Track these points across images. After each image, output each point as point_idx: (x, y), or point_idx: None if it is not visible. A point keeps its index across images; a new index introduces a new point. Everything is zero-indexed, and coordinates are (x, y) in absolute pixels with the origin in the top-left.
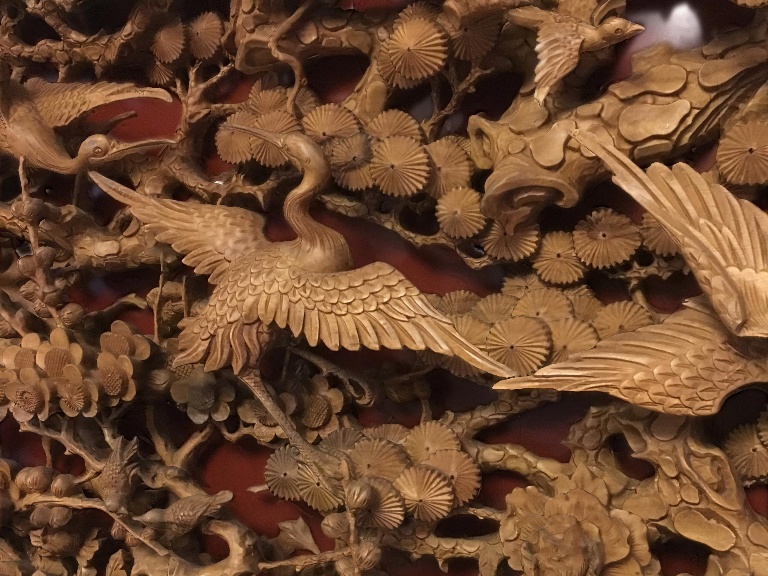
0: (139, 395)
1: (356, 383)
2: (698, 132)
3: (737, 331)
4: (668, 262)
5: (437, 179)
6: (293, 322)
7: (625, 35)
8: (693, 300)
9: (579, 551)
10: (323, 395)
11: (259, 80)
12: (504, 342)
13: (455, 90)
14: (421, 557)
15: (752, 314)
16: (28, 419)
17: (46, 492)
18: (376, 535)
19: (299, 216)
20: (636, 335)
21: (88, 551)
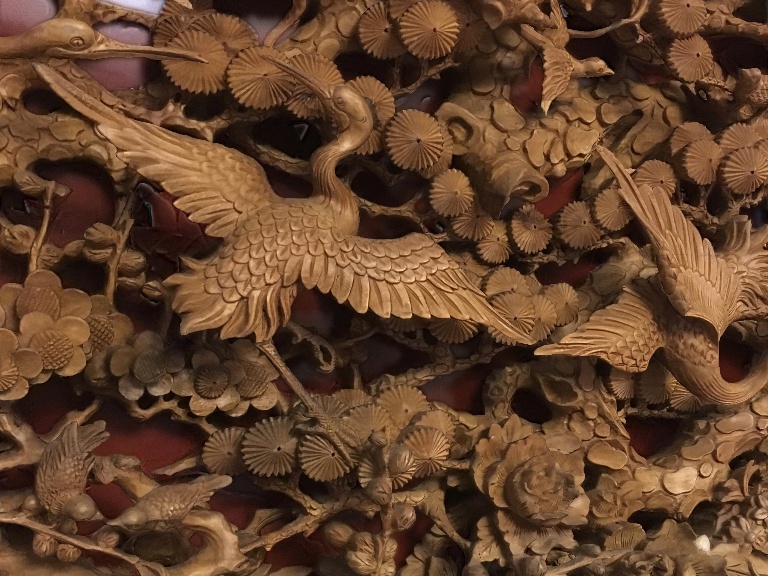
0: None
1: (325, 349)
2: None
3: None
4: (565, 253)
5: None
6: (339, 287)
7: (601, 74)
8: (628, 287)
9: None
10: (255, 362)
11: None
12: (508, 314)
13: (424, 73)
14: (375, 514)
15: None
16: None
17: None
18: (338, 500)
19: (334, 175)
20: (607, 312)
21: None
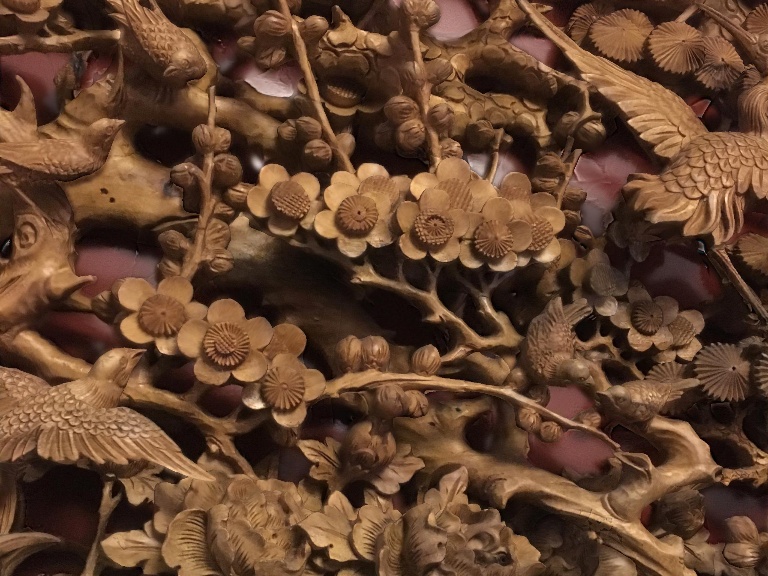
0: (527, 266)
1: None
2: None
3: None
4: None
5: None
6: None
7: None
8: None
9: None
10: None
11: (589, 4)
12: None
13: None
14: None
15: None
16: (421, 256)
17: (386, 371)
18: None
19: (763, 111)
20: None
21: (401, 470)
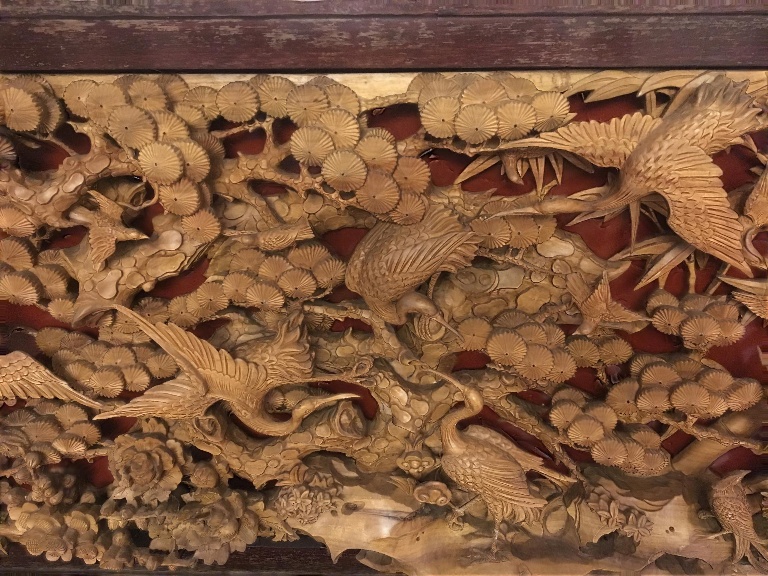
0: None
1: None
2: (193, 261)
3: (204, 396)
4: None
5: (45, 291)
6: None
7: None
8: None
9: (149, 472)
10: None
11: None
12: (98, 385)
13: (47, 229)
14: (77, 459)
15: (211, 387)
16: None
17: None
18: None
19: None
20: (163, 386)
21: None
